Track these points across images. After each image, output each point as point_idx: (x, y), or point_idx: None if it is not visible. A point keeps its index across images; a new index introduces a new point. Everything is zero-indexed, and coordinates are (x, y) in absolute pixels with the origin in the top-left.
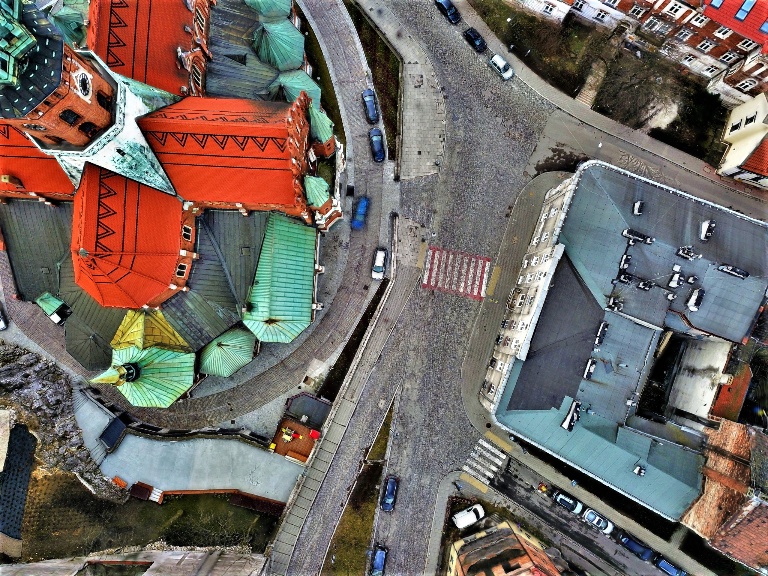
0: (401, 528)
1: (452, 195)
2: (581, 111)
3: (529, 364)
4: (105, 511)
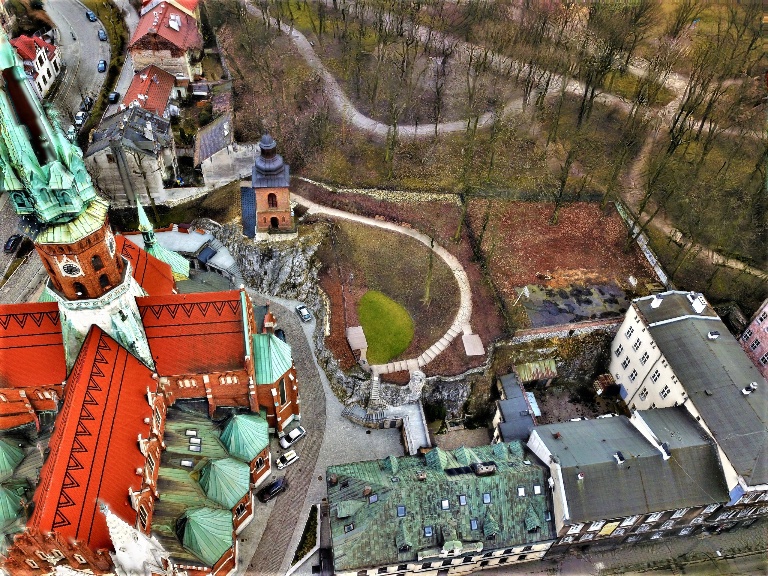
0: (11, 229)
1: None
2: None
3: None
4: (203, 213)
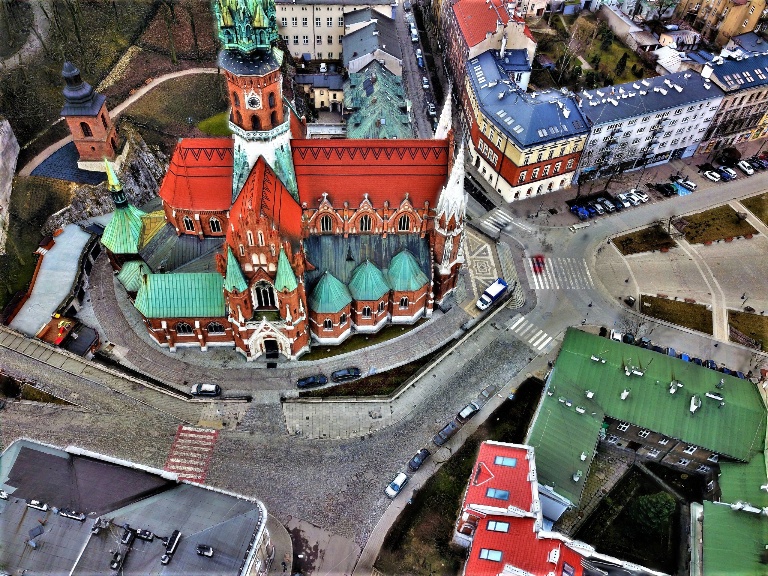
0: None
1: (267, 448)
2: (361, 575)
3: (63, 462)
4: (38, 221)
